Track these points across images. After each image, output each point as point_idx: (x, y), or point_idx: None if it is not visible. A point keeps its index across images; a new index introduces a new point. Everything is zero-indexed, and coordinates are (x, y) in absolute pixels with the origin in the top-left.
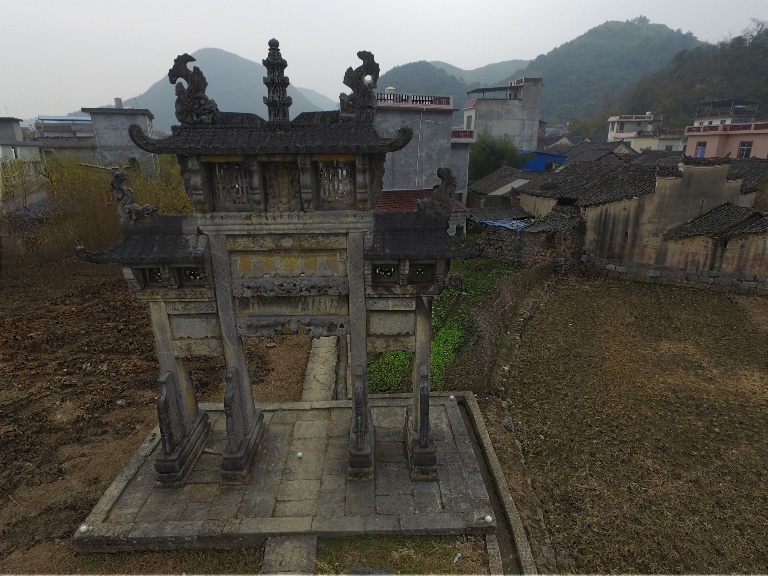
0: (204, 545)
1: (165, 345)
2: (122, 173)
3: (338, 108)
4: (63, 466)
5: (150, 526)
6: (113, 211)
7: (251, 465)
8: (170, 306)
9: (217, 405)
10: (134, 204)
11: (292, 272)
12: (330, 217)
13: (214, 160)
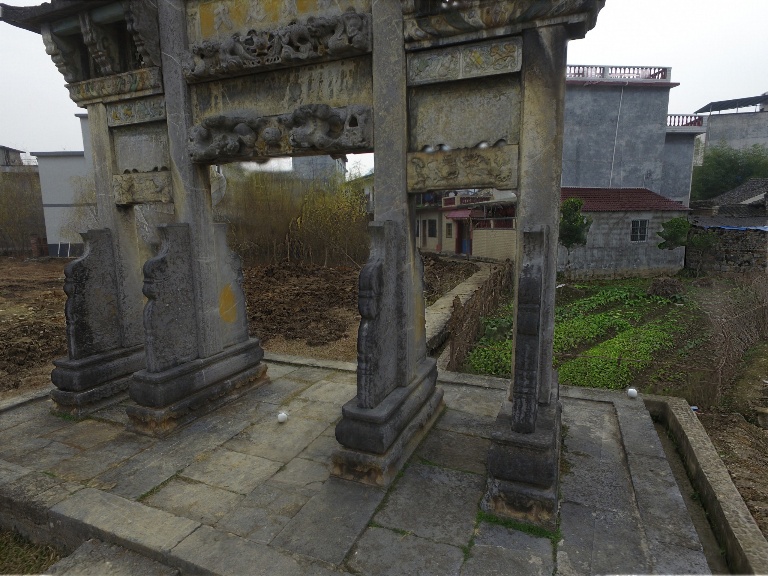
0: (3, 517)
1: (104, 181)
2: None
3: None
4: None
5: None
6: (260, 195)
7: (191, 412)
8: (111, 112)
9: None
10: None
11: (276, 22)
12: None
13: None
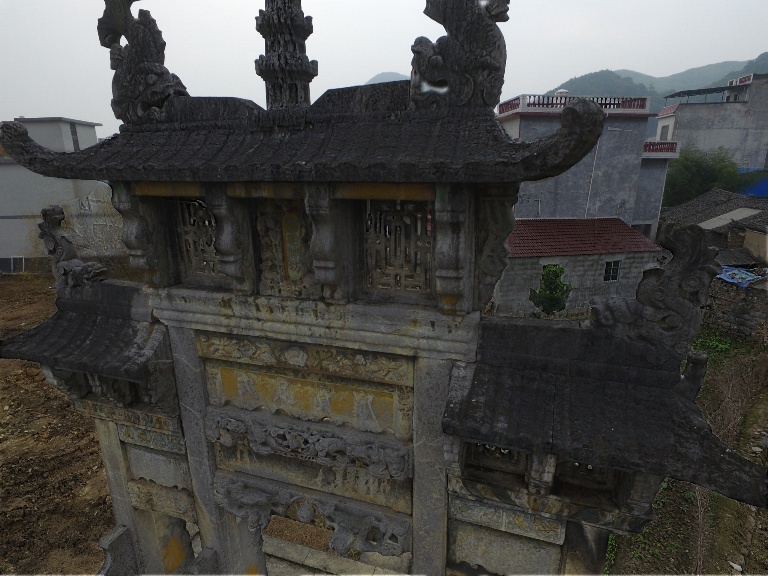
0: None
1: (118, 486)
2: (53, 209)
3: None
4: None
5: None
6: None
7: None
8: (122, 429)
9: None
10: (72, 261)
11: (307, 412)
12: (379, 320)
13: (155, 192)
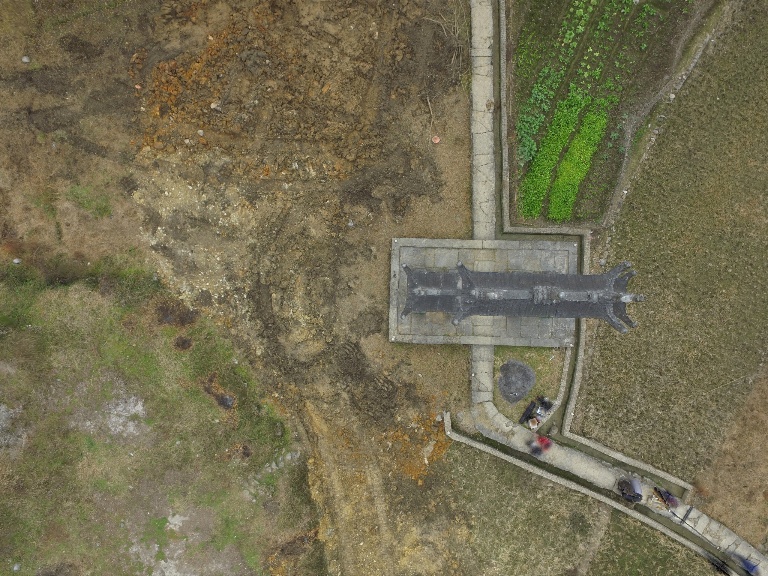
0: None
1: None
2: None
3: (588, 300)
4: (350, 285)
5: (420, 338)
6: None
7: None
8: None
9: (421, 241)
10: None
11: None
12: None
13: None
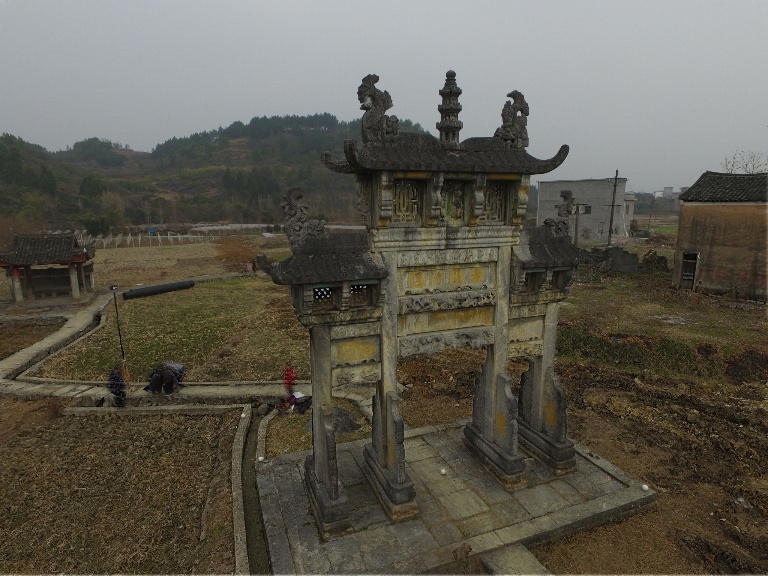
0: None
1: None
2: None
3: None
4: None
5: None
6: None
7: None
8: None
9: (608, 503)
10: None
11: None
12: None
13: None
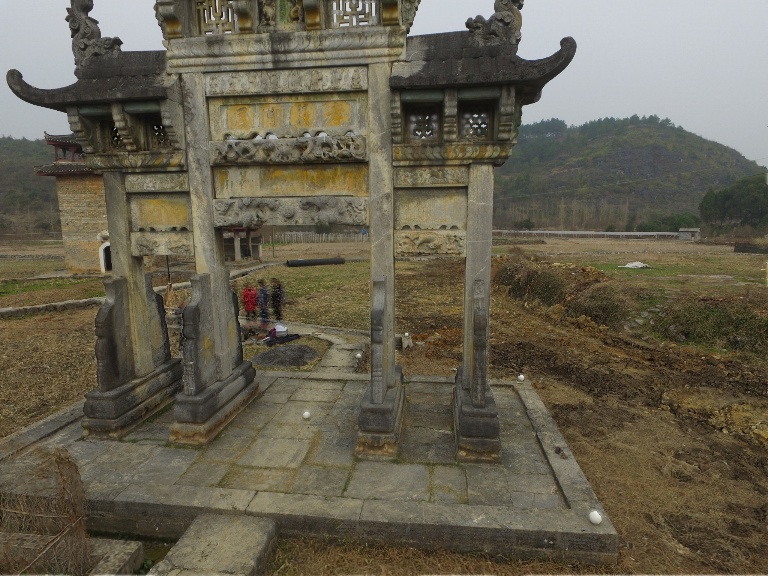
0: None
1: None
2: None
3: None
4: None
5: None
6: None
7: None
8: None
9: (488, 517)
10: None
11: (288, 132)
12: None
13: None
